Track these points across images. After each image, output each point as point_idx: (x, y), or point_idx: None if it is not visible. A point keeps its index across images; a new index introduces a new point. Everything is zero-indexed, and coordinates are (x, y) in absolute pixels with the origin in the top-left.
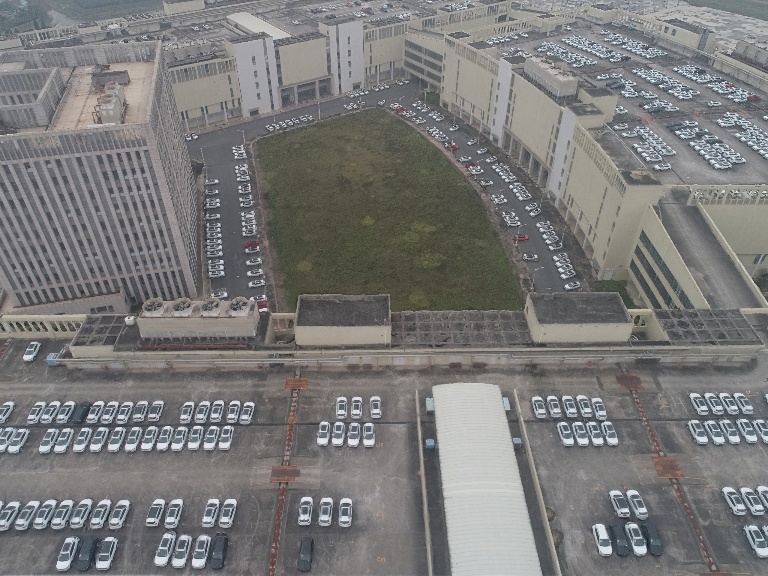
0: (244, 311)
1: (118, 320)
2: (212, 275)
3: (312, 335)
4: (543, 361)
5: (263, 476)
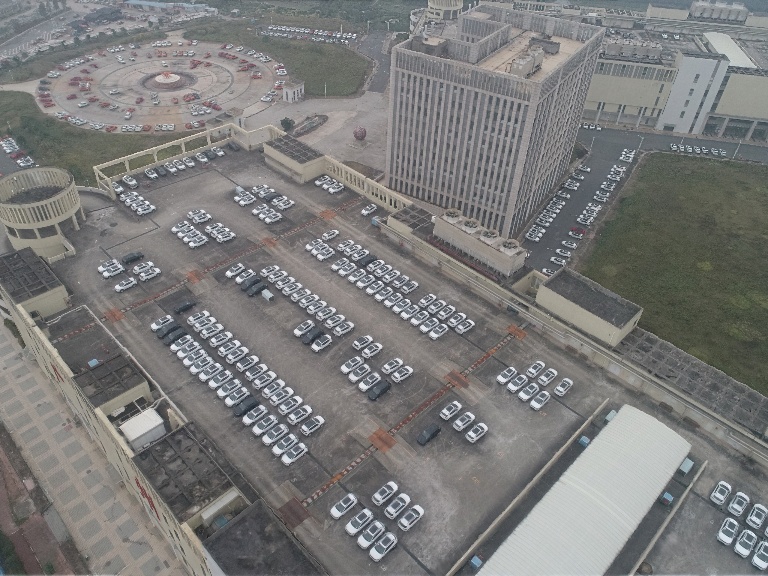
0: (511, 251)
1: (429, 216)
2: (528, 236)
3: (551, 300)
4: (767, 464)
5: (442, 371)
